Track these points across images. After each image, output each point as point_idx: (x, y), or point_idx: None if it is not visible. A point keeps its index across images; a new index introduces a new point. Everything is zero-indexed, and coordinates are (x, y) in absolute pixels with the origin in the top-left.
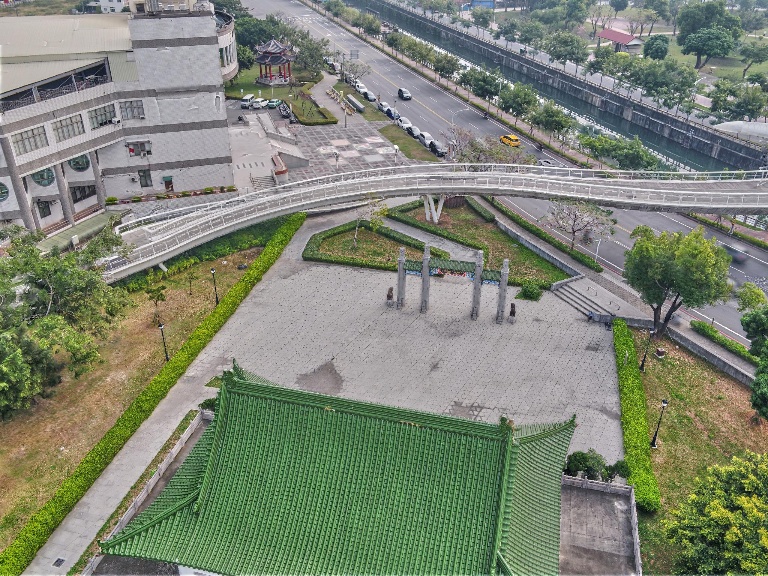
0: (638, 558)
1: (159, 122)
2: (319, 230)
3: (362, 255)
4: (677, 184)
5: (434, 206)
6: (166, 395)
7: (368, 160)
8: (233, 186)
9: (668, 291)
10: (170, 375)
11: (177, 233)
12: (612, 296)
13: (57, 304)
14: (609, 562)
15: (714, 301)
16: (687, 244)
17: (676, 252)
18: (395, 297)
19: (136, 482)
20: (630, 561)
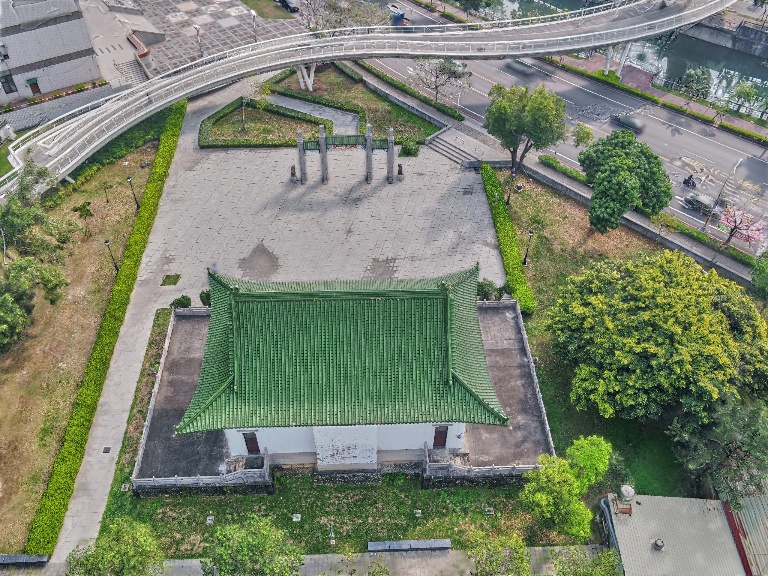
0: (528, 348)
1: (10, 23)
2: (204, 114)
3: (254, 135)
4: (516, 31)
5: (306, 74)
6: (130, 301)
7: (223, 25)
8: (101, 78)
9: (521, 137)
10: (127, 283)
11: (76, 145)
12: (476, 142)
13: (6, 242)
14: (509, 355)
15: (557, 142)
16: (535, 101)
17: (526, 108)
18: (296, 173)
19: (139, 377)
20: (522, 351)
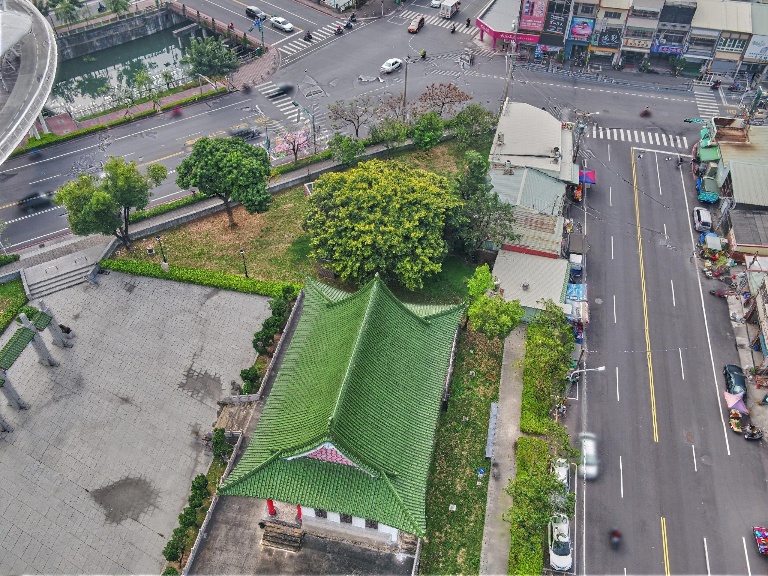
0: None
1: None
2: None
3: None
4: None
5: None
6: None
7: None
8: None
9: None
10: None
11: None
12: (64, 259)
13: None
14: None
15: (151, 192)
16: (125, 172)
17: (120, 183)
18: None
19: None
20: None
